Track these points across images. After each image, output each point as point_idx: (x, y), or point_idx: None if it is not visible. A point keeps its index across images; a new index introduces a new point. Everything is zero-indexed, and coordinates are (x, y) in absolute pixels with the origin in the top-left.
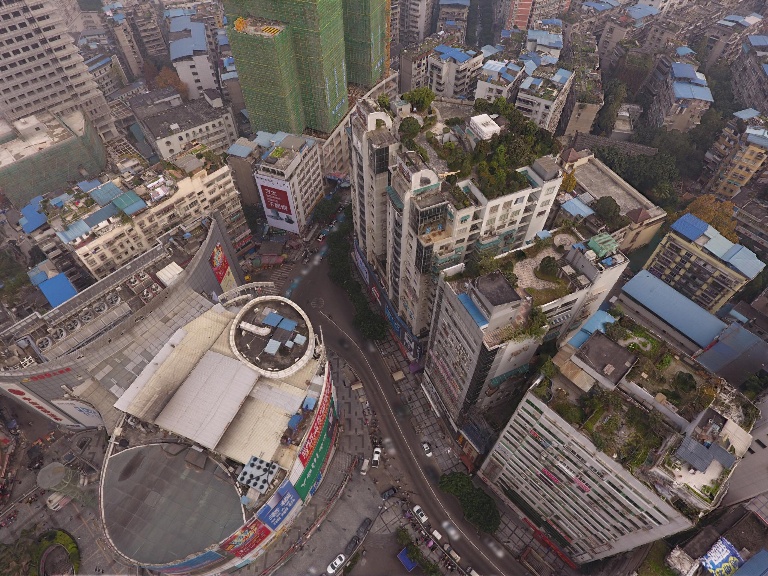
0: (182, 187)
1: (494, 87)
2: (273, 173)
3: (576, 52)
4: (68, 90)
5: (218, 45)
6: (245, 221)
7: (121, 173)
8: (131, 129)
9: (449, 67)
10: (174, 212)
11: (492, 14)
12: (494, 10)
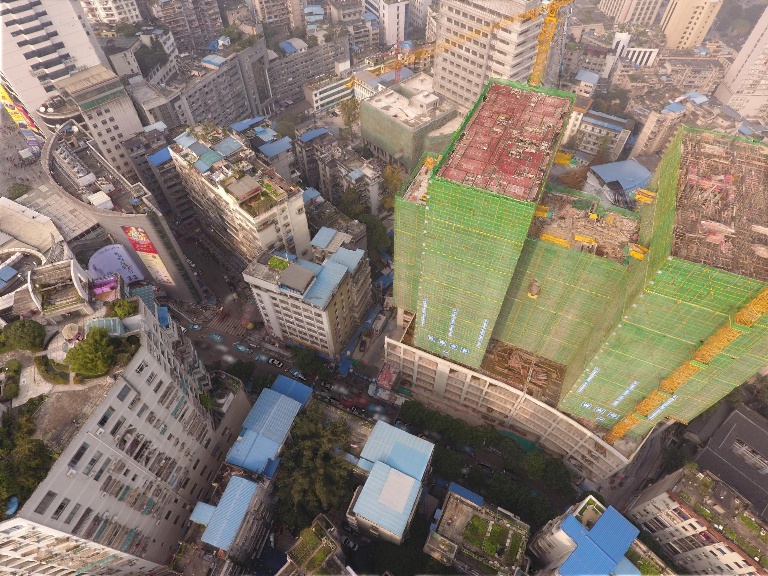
0: None
1: None
2: None
3: None
4: None
5: None
6: None
7: None
8: None
9: None
10: None
11: None
12: None
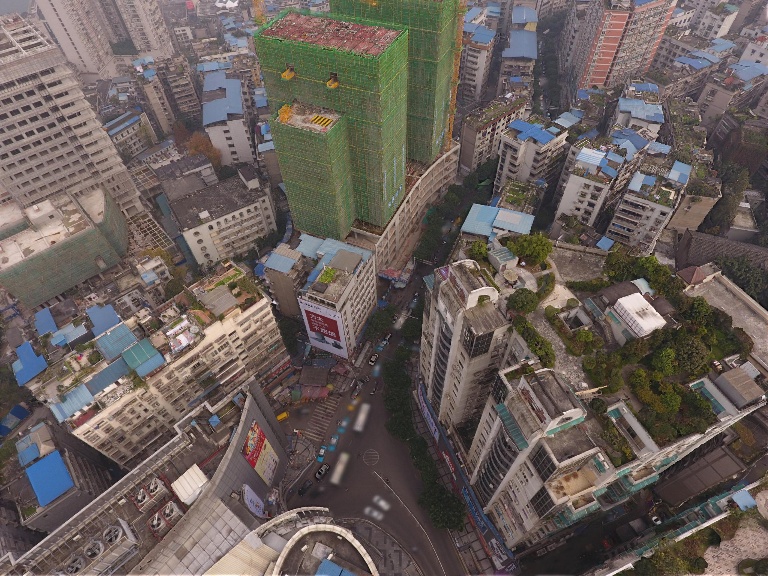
0: (210, 333)
1: (592, 183)
2: (322, 303)
3: (676, 124)
4: (88, 168)
5: (255, 106)
6: (284, 349)
7: (141, 277)
8: (157, 200)
9: (527, 147)
10: (199, 361)
11: (556, 62)
12: (558, 57)
